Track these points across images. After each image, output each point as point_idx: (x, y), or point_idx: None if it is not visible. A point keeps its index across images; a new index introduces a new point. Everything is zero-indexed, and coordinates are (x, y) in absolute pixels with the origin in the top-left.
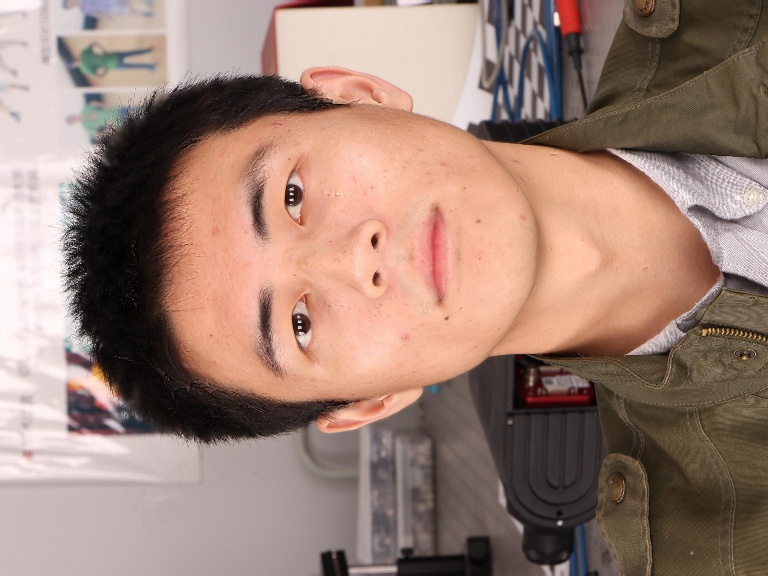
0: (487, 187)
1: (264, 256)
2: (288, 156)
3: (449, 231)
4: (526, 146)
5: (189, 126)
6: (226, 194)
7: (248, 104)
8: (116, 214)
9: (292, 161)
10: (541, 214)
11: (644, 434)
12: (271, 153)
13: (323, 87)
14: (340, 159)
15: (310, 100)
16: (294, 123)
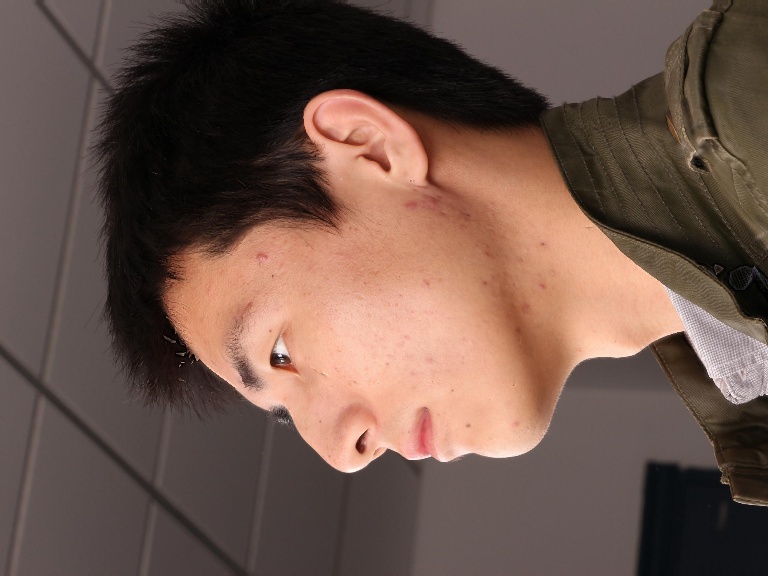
0: (478, 387)
1: (264, 395)
2: (269, 328)
3: (436, 440)
4: (561, 207)
5: (173, 240)
6: (214, 347)
7: (232, 218)
8: (116, 322)
9: (273, 334)
10: (565, 325)
11: None
12: (250, 326)
13: (330, 124)
14: (320, 348)
15: (309, 172)
16: (279, 258)
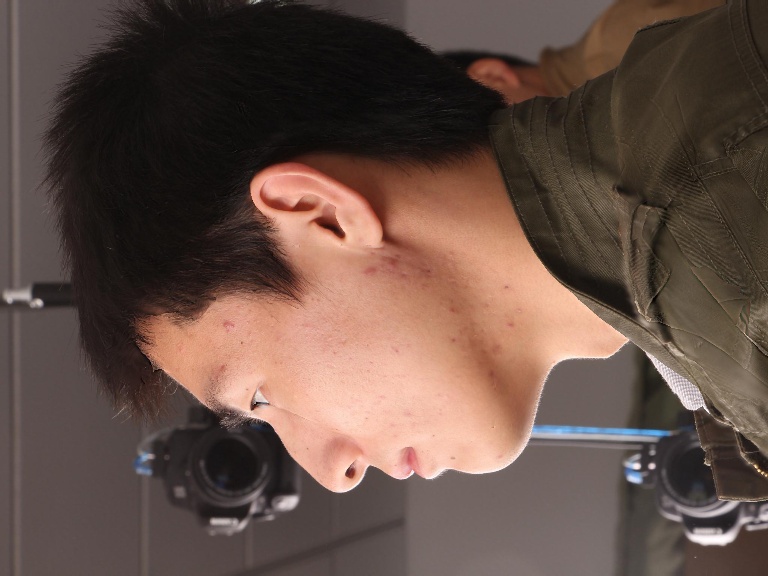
0: (458, 432)
1: None
2: (245, 387)
3: (423, 470)
4: (520, 253)
5: (138, 308)
6: None
7: (193, 293)
8: None
9: (250, 391)
10: (537, 351)
11: (735, 174)
12: (226, 387)
13: (278, 195)
14: (298, 407)
15: (264, 242)
16: (246, 327)
